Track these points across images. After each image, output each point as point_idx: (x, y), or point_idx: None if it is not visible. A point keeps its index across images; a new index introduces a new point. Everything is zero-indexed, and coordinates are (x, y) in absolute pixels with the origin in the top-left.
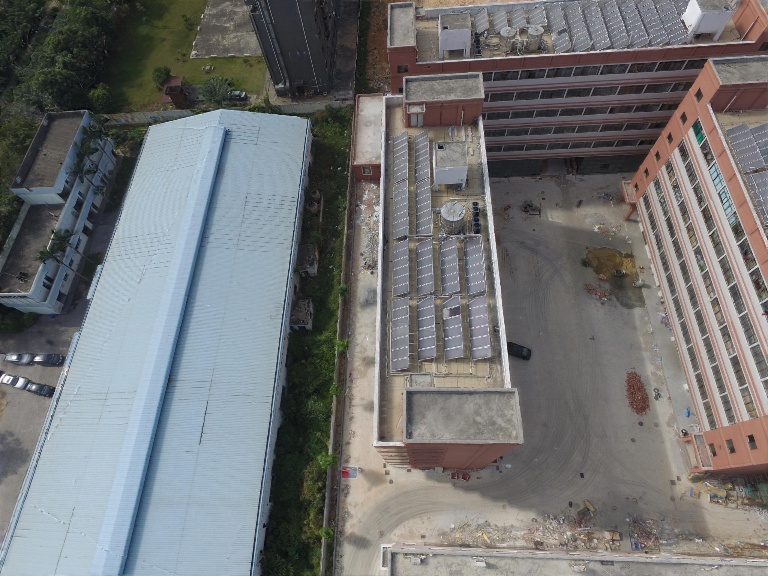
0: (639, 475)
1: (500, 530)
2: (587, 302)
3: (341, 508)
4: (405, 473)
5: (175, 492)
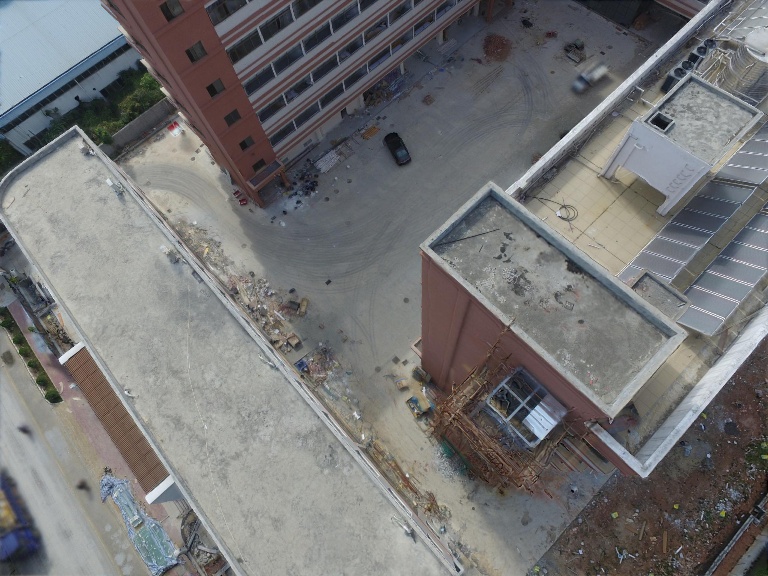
0: (374, 327)
1: (221, 256)
2: (520, 168)
3: (144, 145)
4: (208, 162)
5: (34, 8)
